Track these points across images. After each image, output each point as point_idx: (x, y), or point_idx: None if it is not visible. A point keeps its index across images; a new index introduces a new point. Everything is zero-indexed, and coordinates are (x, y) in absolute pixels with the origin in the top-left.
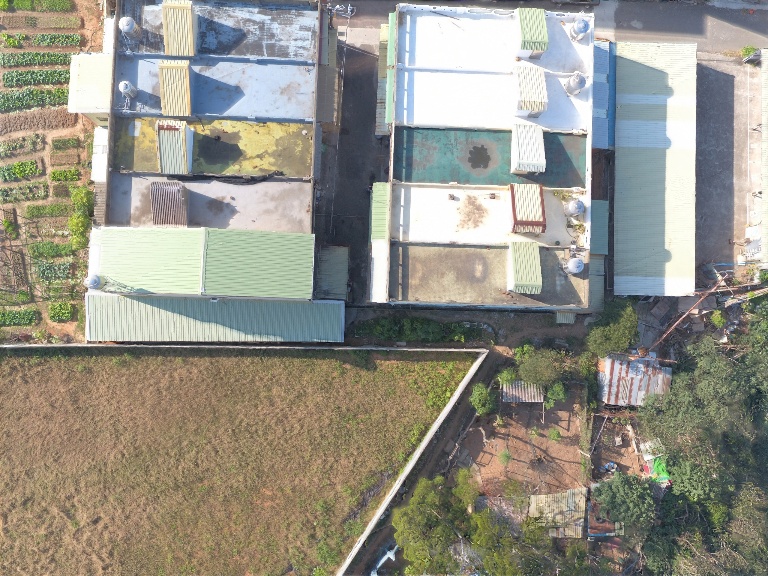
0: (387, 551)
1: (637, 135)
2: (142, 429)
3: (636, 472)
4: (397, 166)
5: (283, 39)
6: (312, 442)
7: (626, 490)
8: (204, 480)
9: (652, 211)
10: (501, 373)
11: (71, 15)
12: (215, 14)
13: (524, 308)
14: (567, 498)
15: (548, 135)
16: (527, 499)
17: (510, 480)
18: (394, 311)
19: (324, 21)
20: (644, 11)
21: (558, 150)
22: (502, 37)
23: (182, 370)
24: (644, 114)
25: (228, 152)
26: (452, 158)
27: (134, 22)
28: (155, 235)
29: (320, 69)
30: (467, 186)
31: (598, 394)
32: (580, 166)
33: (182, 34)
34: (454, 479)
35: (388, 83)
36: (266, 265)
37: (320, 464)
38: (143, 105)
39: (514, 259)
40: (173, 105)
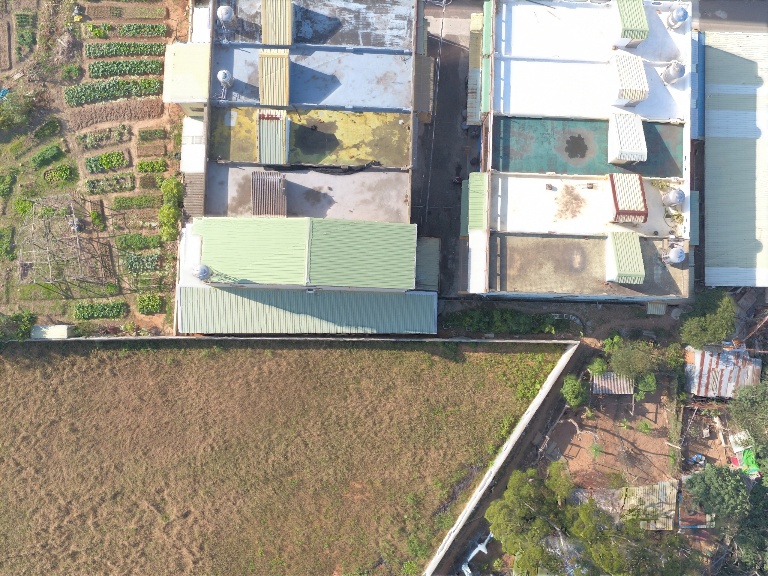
0: (478, 544)
1: (727, 125)
2: (231, 422)
3: (723, 464)
4: (494, 156)
5: (379, 28)
6: (402, 435)
7: (719, 482)
8: (293, 473)
9: (743, 201)
10: (592, 365)
11: (156, 5)
12: (310, 3)
13: (612, 299)
14: (658, 490)
15: (645, 124)
16: (618, 491)
17: (598, 472)
18: (482, 303)
19: (420, 10)
20: (728, 1)
21: (655, 139)
22: (598, 26)
23: (271, 362)
24: (734, 104)
25: (325, 142)
26: (549, 148)
27: (232, 11)
28: (258, 225)
29: (416, 58)
30: (565, 176)
31: (685, 386)
32: (677, 155)
33: (280, 23)
34: (542, 472)
35: (484, 72)
36: (369, 255)
37: (410, 457)
38: (239, 95)
39: (615, 249)
40: (271, 94)
